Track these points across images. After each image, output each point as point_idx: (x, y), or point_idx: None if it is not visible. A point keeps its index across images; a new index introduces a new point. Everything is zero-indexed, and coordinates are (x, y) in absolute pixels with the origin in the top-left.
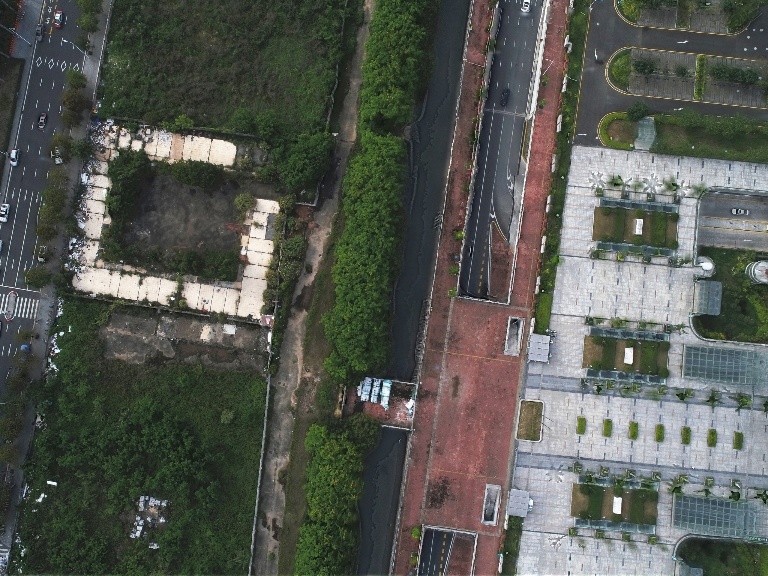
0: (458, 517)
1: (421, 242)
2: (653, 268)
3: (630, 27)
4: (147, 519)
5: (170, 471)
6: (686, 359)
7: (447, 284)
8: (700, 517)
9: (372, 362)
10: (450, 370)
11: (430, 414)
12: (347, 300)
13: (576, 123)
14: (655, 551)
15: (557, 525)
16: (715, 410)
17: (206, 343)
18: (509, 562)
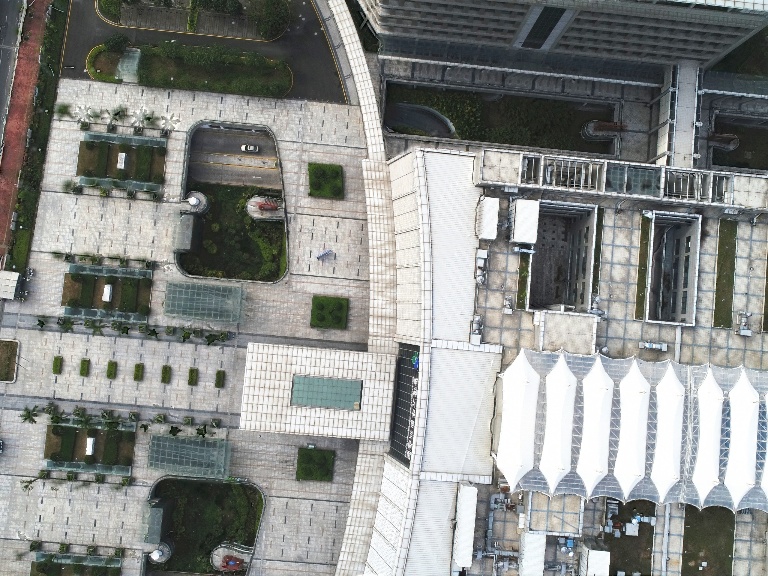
0: None
1: None
2: (139, 203)
3: None
4: None
5: None
6: (167, 296)
7: None
8: (170, 457)
9: None
10: None
11: None
12: None
13: (64, 55)
14: (131, 493)
15: (29, 468)
16: (198, 348)
17: None
18: None
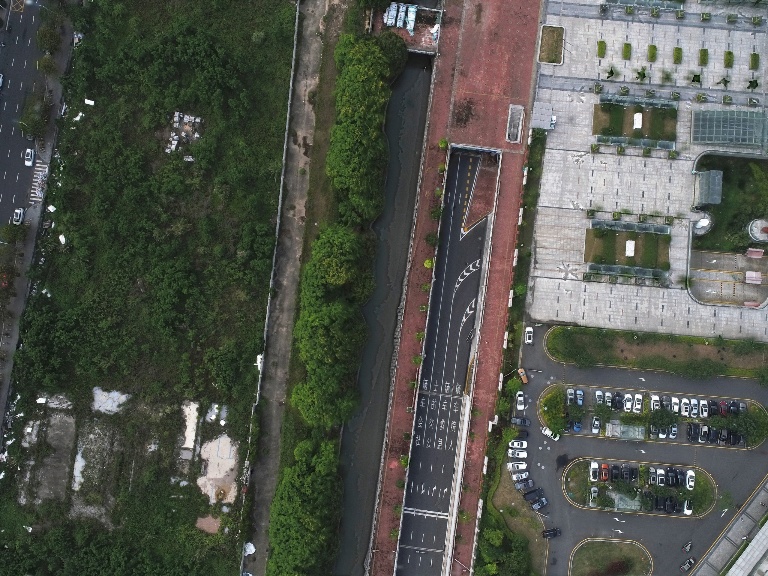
0: (483, 136)
1: None
2: None
3: None
4: (182, 135)
5: (204, 77)
6: None
7: None
8: (719, 128)
9: None
10: None
11: (454, 39)
12: None
13: None
14: (675, 167)
15: (579, 143)
16: (731, 34)
17: None
18: (533, 178)
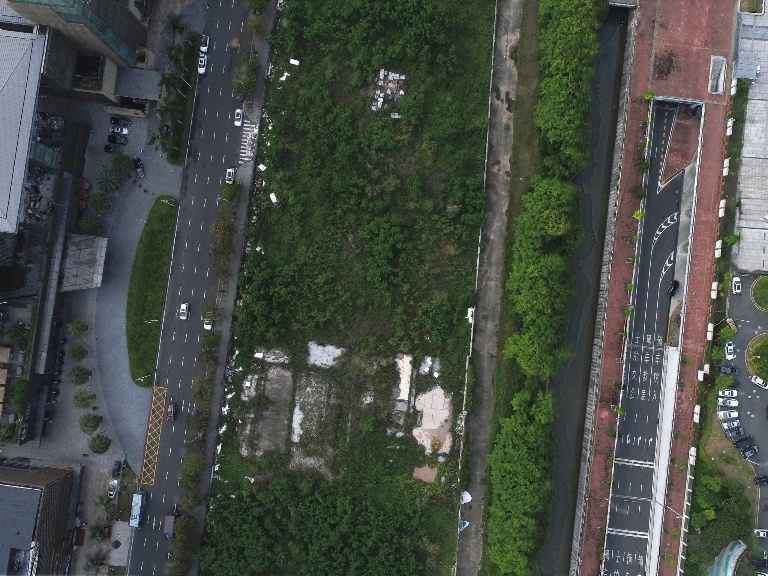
0: (685, 87)
1: None
2: None
3: None
4: (387, 92)
5: (414, 33)
6: None
7: None
8: None
9: None
10: None
11: None
12: None
13: None
14: None
15: None
16: None
17: None
18: (736, 129)
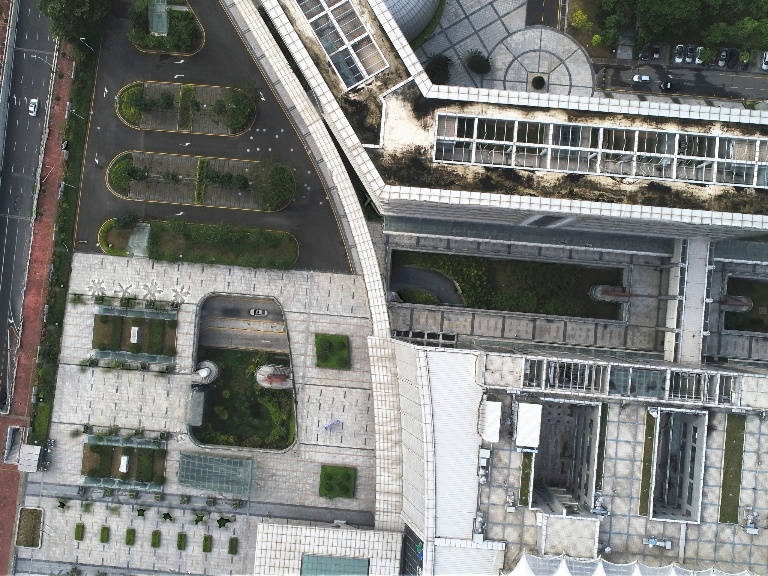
0: None
1: None
2: (152, 375)
3: (132, 130)
4: None
5: None
6: (181, 466)
7: None
8: None
9: None
10: None
11: None
12: None
13: (77, 230)
14: None
15: None
16: (211, 516)
17: None
18: None
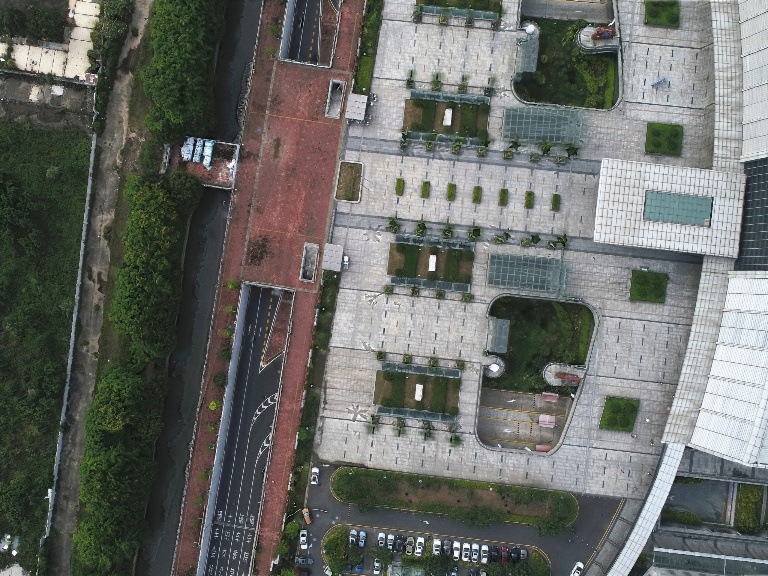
0: (277, 274)
1: (244, 4)
2: (476, 32)
3: None
4: None
5: None
6: (505, 121)
7: (270, 48)
8: (512, 274)
9: (188, 116)
10: (272, 132)
11: (251, 175)
12: (161, 52)
13: None
14: (469, 309)
15: (374, 283)
16: (534, 173)
17: (35, 103)
18: (326, 318)
